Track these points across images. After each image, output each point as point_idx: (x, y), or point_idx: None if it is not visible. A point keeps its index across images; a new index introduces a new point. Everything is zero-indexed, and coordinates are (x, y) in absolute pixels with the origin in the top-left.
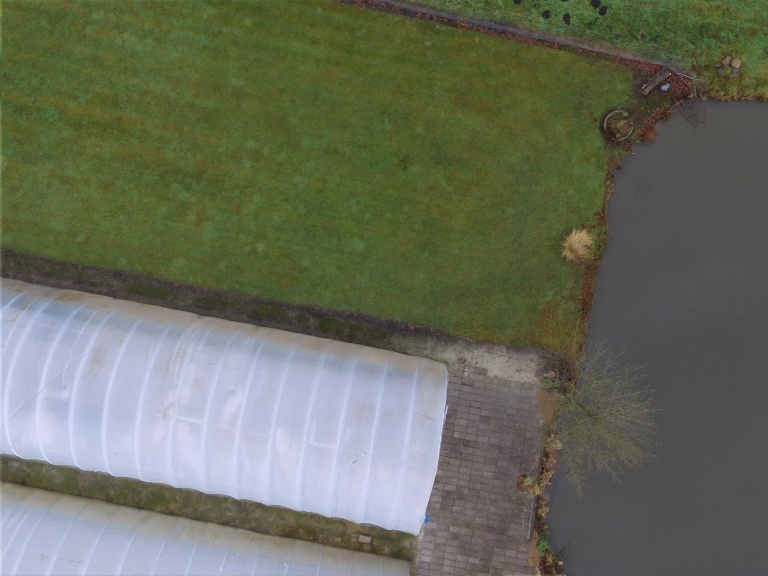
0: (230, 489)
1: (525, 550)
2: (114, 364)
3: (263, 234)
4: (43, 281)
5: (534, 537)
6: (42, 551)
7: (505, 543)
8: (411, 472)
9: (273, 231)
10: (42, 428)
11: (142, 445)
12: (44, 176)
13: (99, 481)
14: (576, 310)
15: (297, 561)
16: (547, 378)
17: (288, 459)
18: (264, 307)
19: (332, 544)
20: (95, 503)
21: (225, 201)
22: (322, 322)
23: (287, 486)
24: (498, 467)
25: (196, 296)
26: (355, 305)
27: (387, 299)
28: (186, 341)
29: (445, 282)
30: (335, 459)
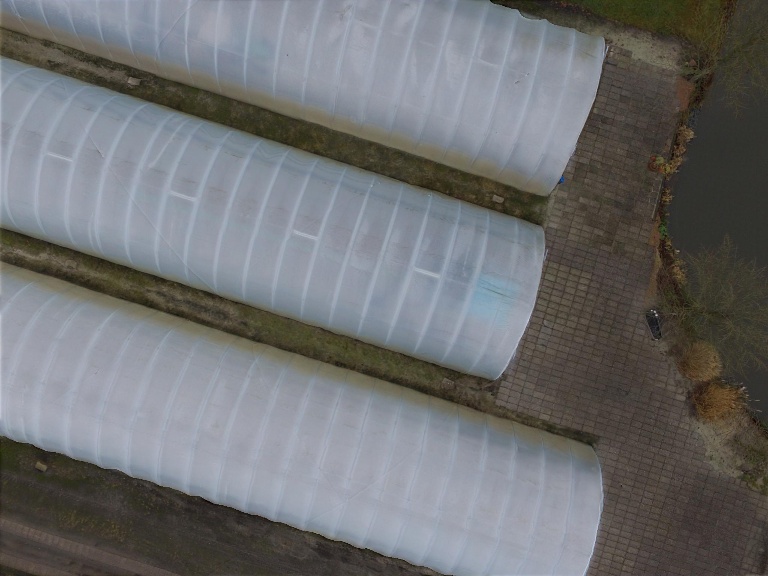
0: (390, 108)
1: (648, 228)
2: None
3: None
4: None
5: (657, 219)
6: (205, 144)
7: (630, 219)
8: (570, 97)
9: None
10: (222, 19)
11: (316, 45)
12: None
13: (251, 115)
14: (722, 7)
15: (439, 197)
16: (688, 66)
17: (455, 72)
18: None
19: (467, 200)
20: (245, 134)
21: None
22: None
23: (448, 104)
24: (632, 146)
25: None
26: None
27: None
28: None
29: None
30: (500, 76)
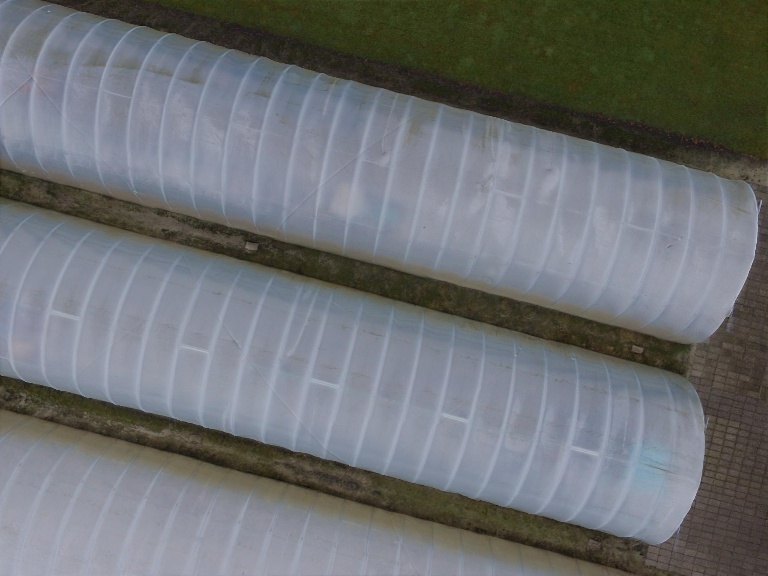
0: (531, 274)
1: None
2: (432, 135)
3: (553, 38)
4: (329, 72)
5: None
6: (341, 322)
7: None
8: (727, 259)
9: (563, 36)
10: (356, 195)
11: (456, 218)
12: None
13: (374, 275)
14: None
15: (582, 358)
16: None
17: (603, 239)
18: (548, 112)
19: (604, 352)
20: (370, 296)
21: (517, 3)
22: (605, 131)
23: (595, 270)
24: None
25: (480, 97)
26: (640, 115)
27: (673, 111)
28: (493, 124)
29: (732, 98)
30: (652, 241)
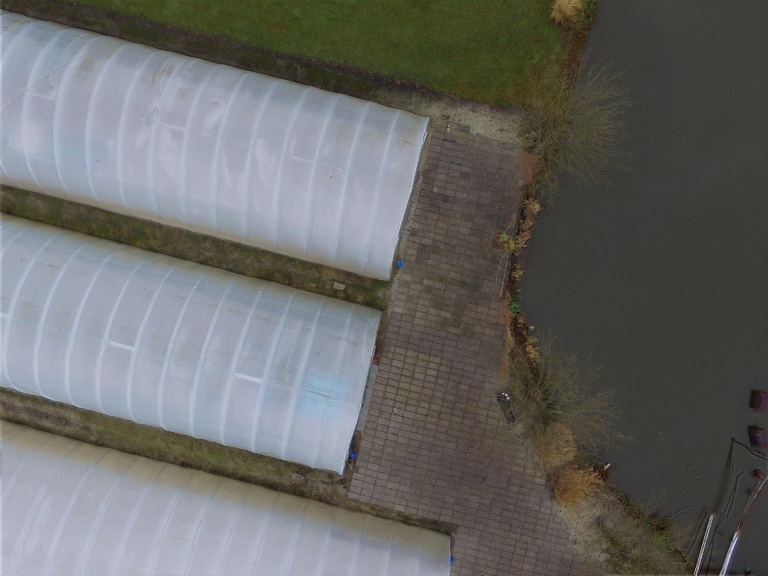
0: (208, 207)
1: (497, 307)
2: (101, 70)
3: None
4: (38, 15)
5: (506, 297)
6: (21, 255)
7: (477, 299)
8: (386, 189)
9: None
10: (27, 128)
11: (124, 150)
12: None
13: (81, 214)
14: (562, 74)
15: (270, 292)
16: (529, 138)
17: (266, 170)
18: (253, 54)
19: (306, 289)
20: (76, 234)
21: None
22: (309, 72)
23: (264, 202)
24: (475, 224)
25: (187, 39)
26: (343, 56)
27: (375, 52)
28: (173, 61)
29: (433, 39)
30: (312, 172)
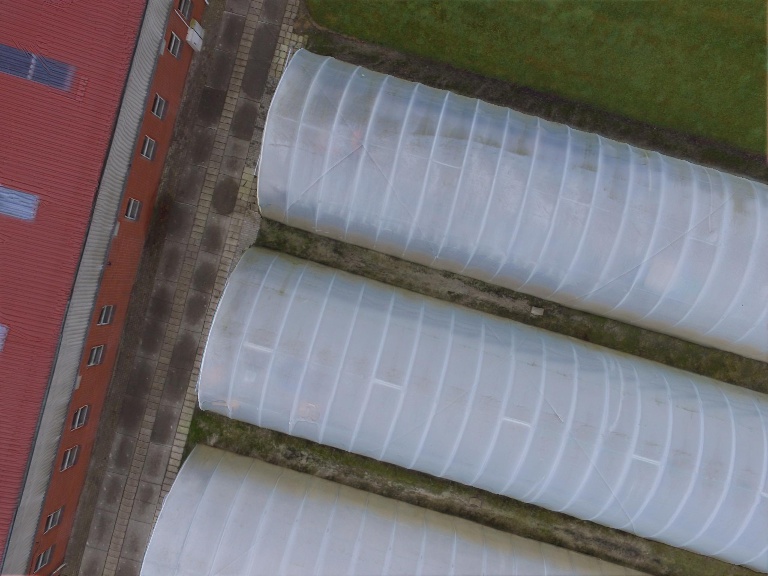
0: None
1: None
2: (757, 214)
3: None
4: (619, 139)
5: None
6: (654, 397)
7: None
8: None
9: None
10: (679, 271)
11: None
12: (629, 34)
13: (659, 343)
14: None
15: None
16: None
17: None
18: None
19: None
20: None
21: None
22: None
23: None
24: None
25: None
26: None
27: None
28: None
29: None
30: None
